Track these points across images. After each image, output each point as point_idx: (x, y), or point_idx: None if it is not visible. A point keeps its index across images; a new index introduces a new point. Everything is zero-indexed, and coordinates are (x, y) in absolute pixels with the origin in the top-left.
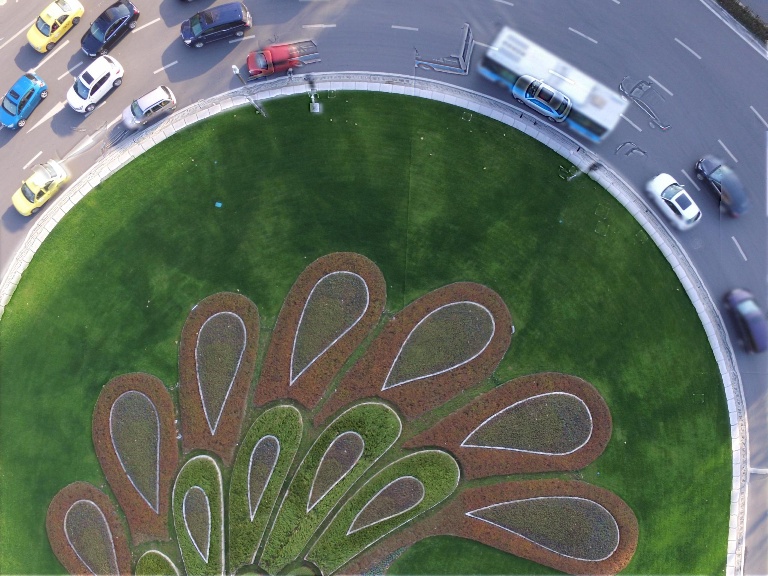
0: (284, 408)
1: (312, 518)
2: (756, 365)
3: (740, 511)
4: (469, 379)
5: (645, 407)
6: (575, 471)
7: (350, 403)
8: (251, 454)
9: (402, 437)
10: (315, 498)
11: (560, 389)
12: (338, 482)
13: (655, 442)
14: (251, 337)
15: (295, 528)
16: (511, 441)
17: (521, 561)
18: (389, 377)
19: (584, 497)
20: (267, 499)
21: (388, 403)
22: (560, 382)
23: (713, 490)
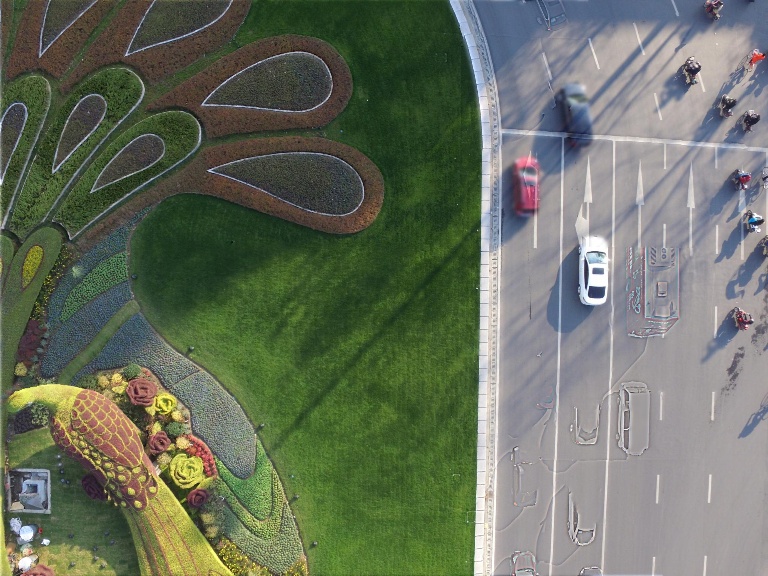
0: (32, 77)
1: (57, 179)
2: (502, 28)
3: (494, 172)
4: (209, 41)
5: (386, 66)
6: (317, 128)
7: (96, 70)
8: (0, 121)
9: (146, 100)
10: (60, 159)
11: (298, 48)
12: (82, 143)
13: (398, 100)
14: (4, 16)
15: (42, 190)
16: (250, 98)
17: (265, 218)
18: (132, 43)
19: (326, 152)
20: (15, 162)
21: (132, 68)
22: (298, 41)
23: (461, 148)
